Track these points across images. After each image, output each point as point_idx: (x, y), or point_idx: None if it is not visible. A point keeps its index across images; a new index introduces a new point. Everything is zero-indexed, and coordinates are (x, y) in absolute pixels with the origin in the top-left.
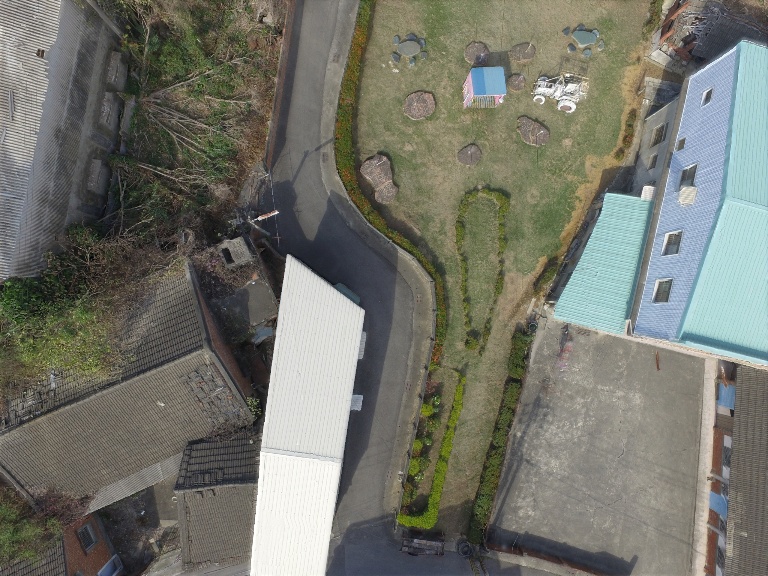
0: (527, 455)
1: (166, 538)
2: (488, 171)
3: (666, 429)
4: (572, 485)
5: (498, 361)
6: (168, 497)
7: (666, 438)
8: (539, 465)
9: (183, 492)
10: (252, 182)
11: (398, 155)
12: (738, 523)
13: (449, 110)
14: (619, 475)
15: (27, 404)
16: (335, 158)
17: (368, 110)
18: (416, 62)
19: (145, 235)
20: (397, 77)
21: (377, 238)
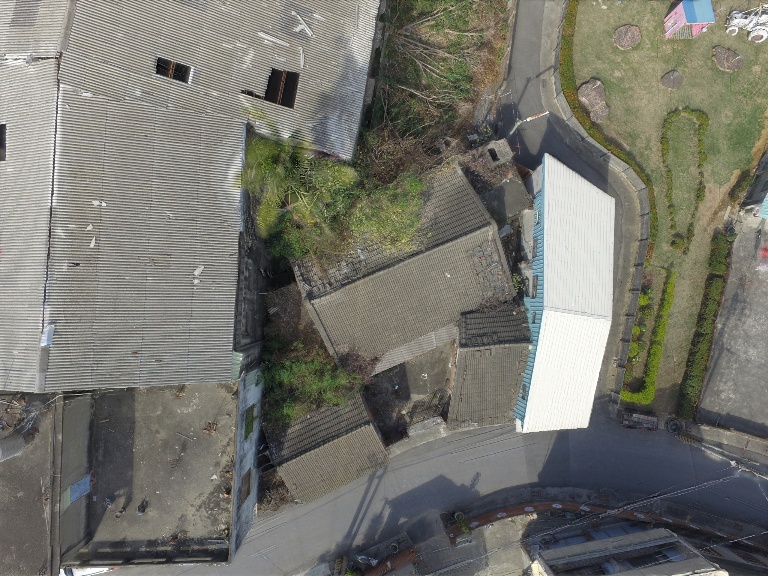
0: (727, 344)
1: (415, 410)
2: (687, 94)
3: None
4: None
5: (699, 261)
6: (417, 374)
7: None
8: (738, 353)
9: (466, 350)
10: (484, 104)
11: (609, 80)
12: None
13: (652, 41)
14: None
15: (343, 272)
16: (560, 81)
17: (581, 42)
18: (622, 0)
19: None
20: (606, 13)
21: (590, 153)
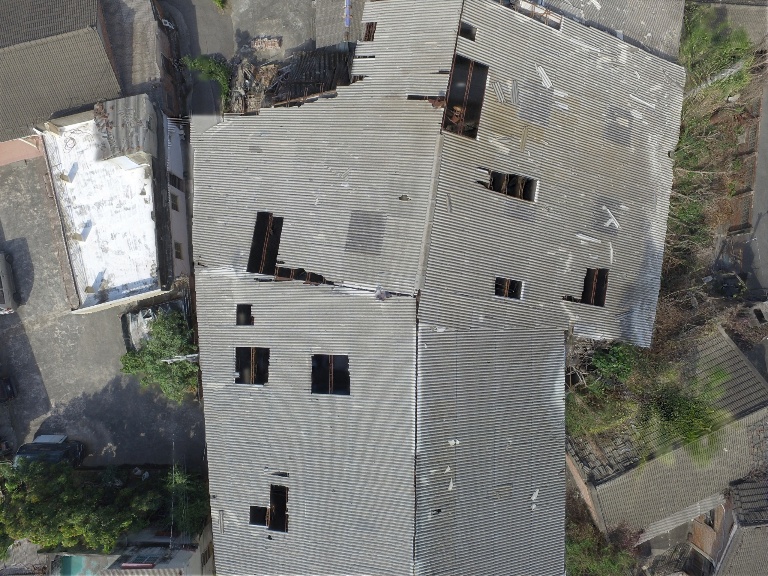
0: None
1: (656, 565)
2: None
3: None
4: None
5: None
6: None
7: None
8: None
9: (747, 528)
10: (716, 243)
11: None
12: None
13: None
14: None
15: (621, 451)
16: None
17: None
18: None
19: None
20: None
21: None
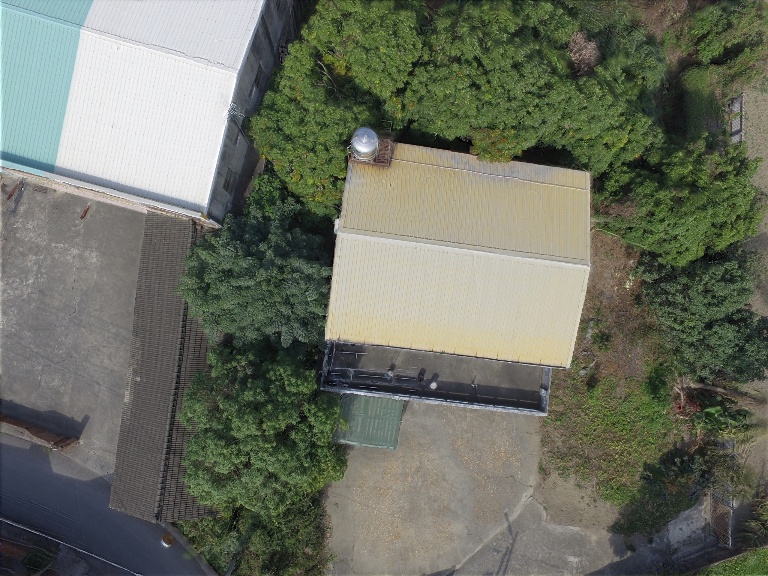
0: None
1: None
2: None
3: (124, 289)
4: (19, 342)
5: None
6: None
7: (123, 298)
8: None
9: None
10: None
11: None
12: (135, 368)
13: None
14: (70, 333)
15: None
16: None
17: None
18: None
19: None
20: None
21: None
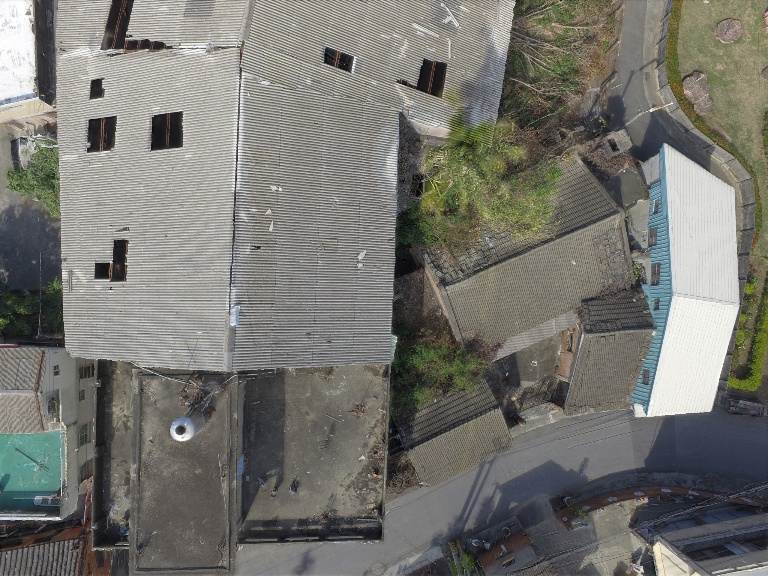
0: None
1: (525, 397)
2: None
3: None
4: None
5: None
6: (527, 362)
7: None
8: None
9: (592, 336)
10: (590, 96)
11: (711, 73)
12: None
13: (753, 35)
14: None
15: (473, 259)
16: (667, 74)
17: (684, 36)
18: None
19: (547, 127)
20: (708, 7)
21: (692, 145)
